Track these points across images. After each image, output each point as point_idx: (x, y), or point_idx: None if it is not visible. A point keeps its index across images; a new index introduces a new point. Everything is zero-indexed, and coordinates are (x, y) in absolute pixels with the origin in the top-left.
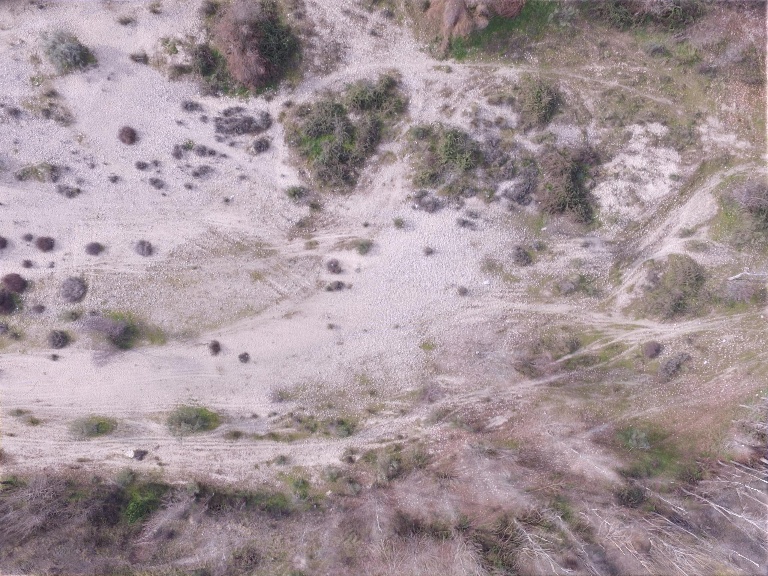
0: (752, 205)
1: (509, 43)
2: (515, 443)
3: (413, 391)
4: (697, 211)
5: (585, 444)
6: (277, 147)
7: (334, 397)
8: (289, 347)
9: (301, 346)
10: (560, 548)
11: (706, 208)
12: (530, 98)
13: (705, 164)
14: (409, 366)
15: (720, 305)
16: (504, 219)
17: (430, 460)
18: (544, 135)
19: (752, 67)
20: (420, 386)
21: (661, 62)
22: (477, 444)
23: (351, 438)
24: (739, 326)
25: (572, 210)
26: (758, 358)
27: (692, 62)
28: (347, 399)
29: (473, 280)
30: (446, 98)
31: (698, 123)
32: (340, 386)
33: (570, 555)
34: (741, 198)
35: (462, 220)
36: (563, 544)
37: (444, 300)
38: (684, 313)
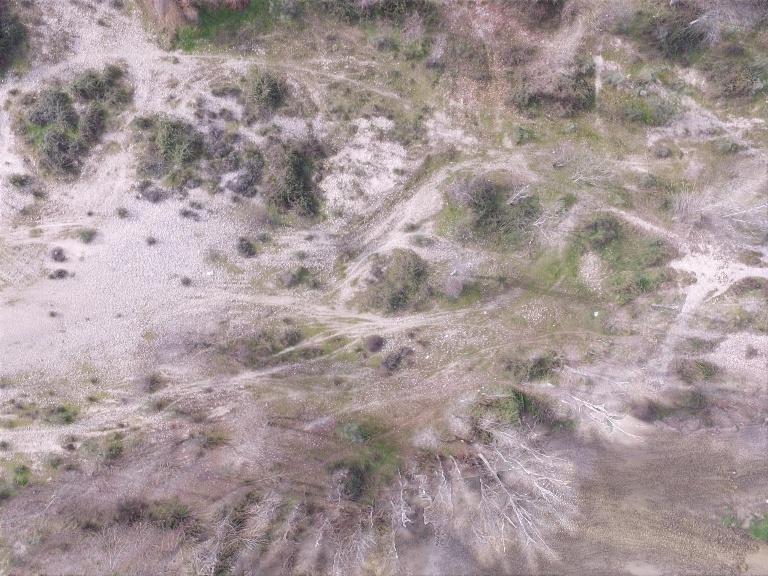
0: (471, 201)
1: (237, 35)
2: (237, 434)
3: (135, 380)
4: (422, 206)
5: (306, 436)
6: (3, 135)
7: (56, 384)
8: (12, 334)
9: (24, 333)
10: (275, 539)
11: (431, 203)
12: (250, 90)
13: (430, 159)
14: (132, 355)
15: (443, 300)
16: (229, 210)
17: (152, 449)
18: (267, 127)
19: (479, 63)
20: (143, 375)
21: (389, 56)
22: (197, 434)
23: (73, 426)
24: (462, 322)
25: (294, 202)
26: (480, 354)
27: (420, 57)
28: (69, 387)
29: (197, 271)
30: (172, 89)
31: (425, 118)
32: (62, 374)
33: (287, 546)
34: (455, 193)
35: (184, 211)
36: (278, 535)
37: (167, 290)
38: (406, 307)
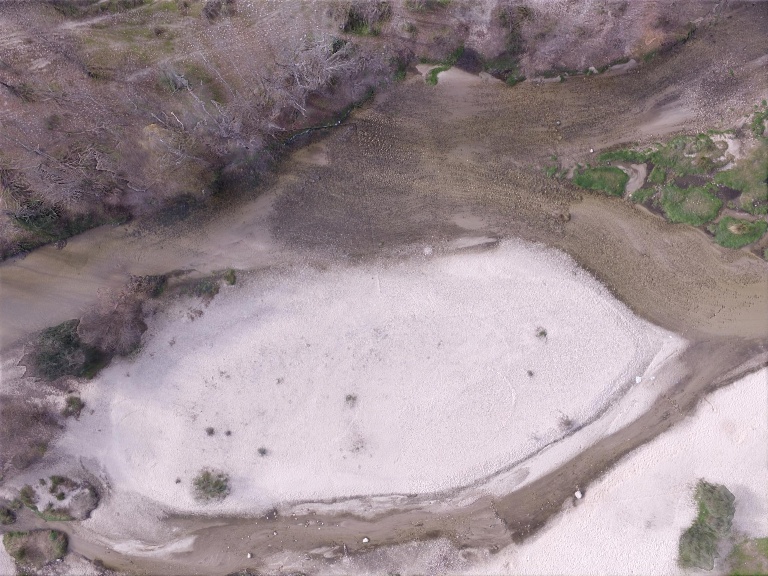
0: None
1: None
2: (59, 86)
3: None
4: None
5: (128, 87)
6: None
7: None
8: None
9: None
10: None
11: None
12: None
13: None
14: None
15: None
16: None
17: None
18: None
19: None
20: None
21: None
22: (17, 84)
23: None
24: None
25: None
26: (302, 1)
27: None
28: None
29: None
30: None
31: None
32: None
33: (111, 197)
34: None
35: None
36: None
37: None
38: None
